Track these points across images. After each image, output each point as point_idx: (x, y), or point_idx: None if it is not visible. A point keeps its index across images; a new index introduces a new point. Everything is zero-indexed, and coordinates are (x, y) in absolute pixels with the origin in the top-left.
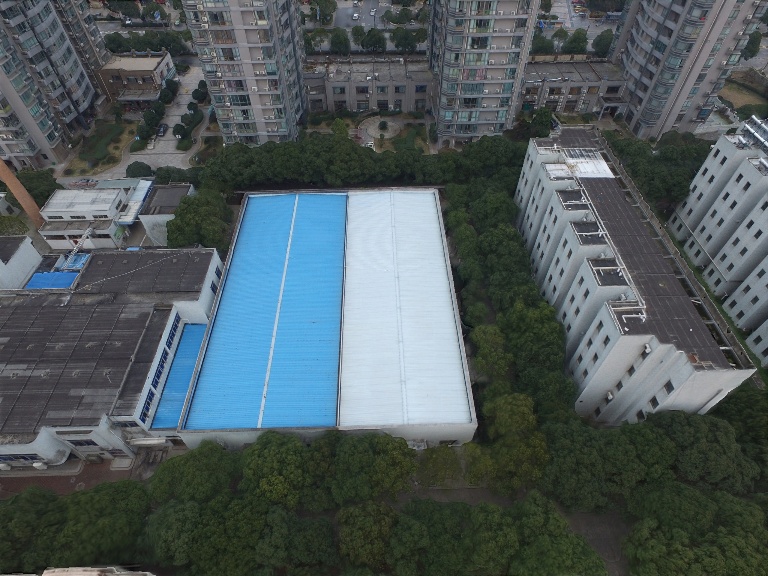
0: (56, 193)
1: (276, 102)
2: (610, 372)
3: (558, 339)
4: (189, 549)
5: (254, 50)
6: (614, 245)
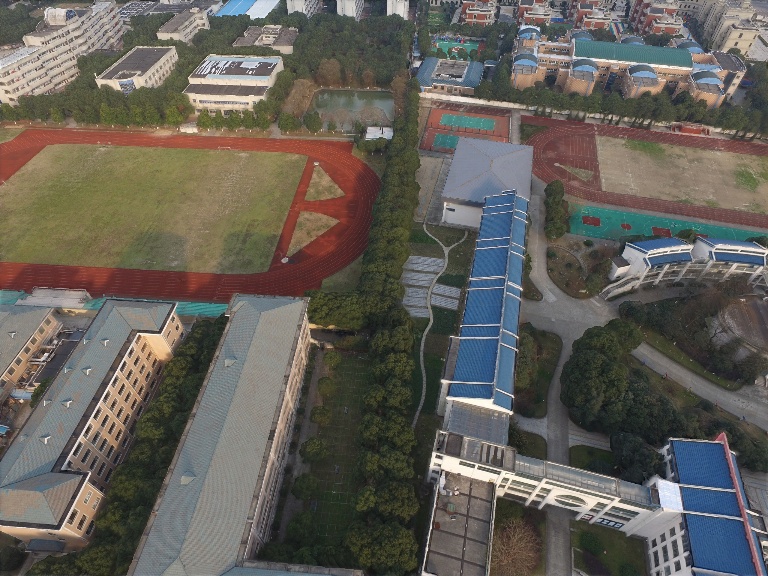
0: None
1: None
2: (290, 10)
3: None
4: (211, 19)
5: None
6: None
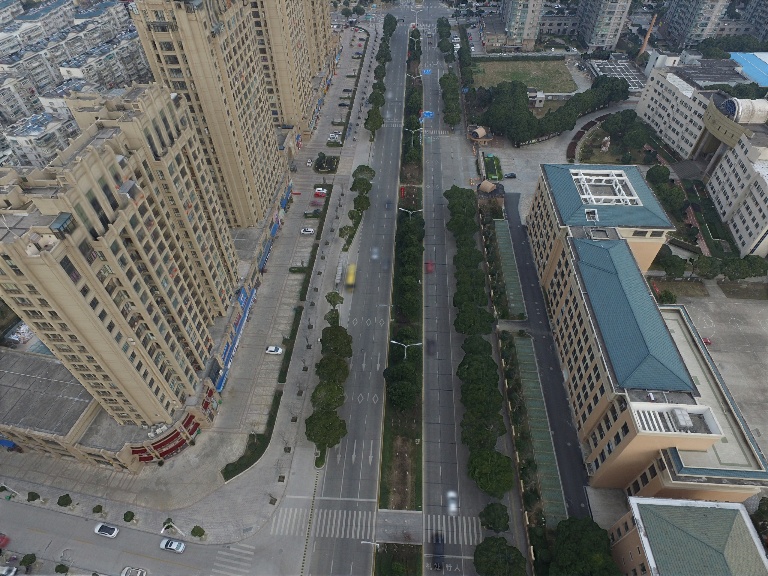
0: None
1: (716, 26)
2: None
3: None
4: None
5: (721, 6)
6: None
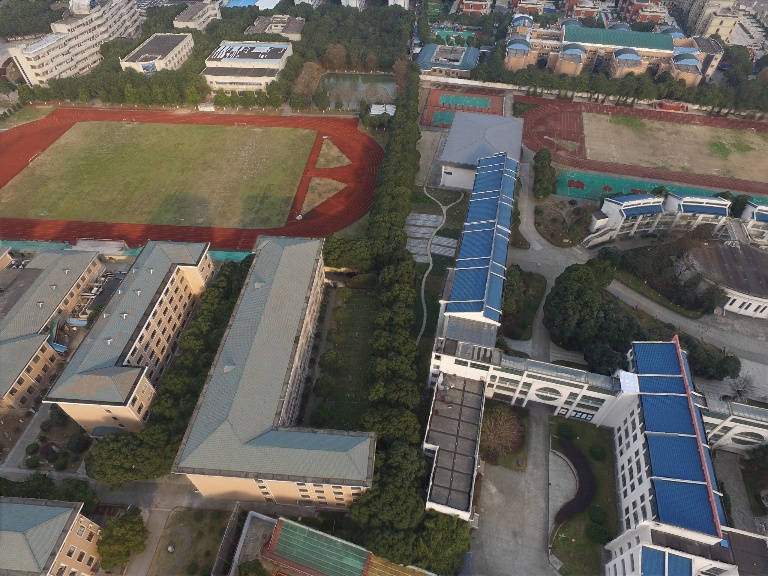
0: None
1: None
2: (297, 1)
3: None
4: (222, 9)
5: None
6: None
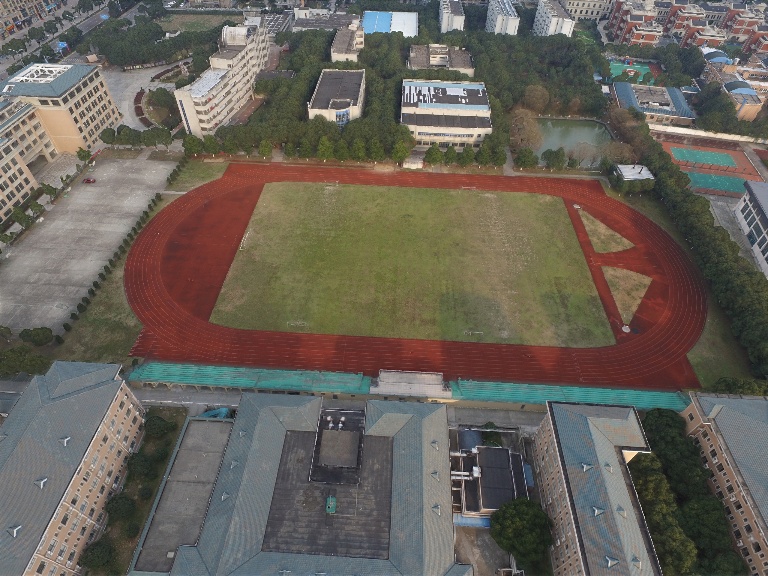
0: (310, 9)
1: None
2: (445, 27)
3: (436, 24)
4: (366, 36)
5: None
6: None
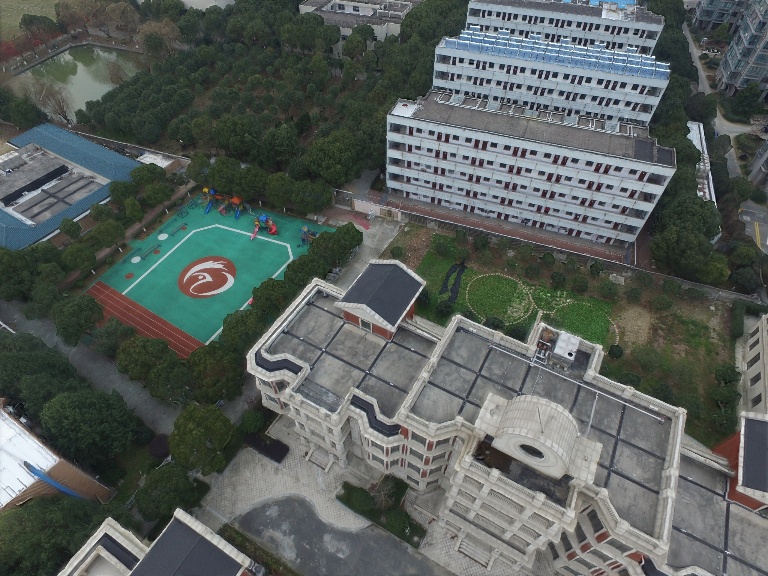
0: None
1: None
2: None
3: None
4: None
5: None
6: (543, 1)
